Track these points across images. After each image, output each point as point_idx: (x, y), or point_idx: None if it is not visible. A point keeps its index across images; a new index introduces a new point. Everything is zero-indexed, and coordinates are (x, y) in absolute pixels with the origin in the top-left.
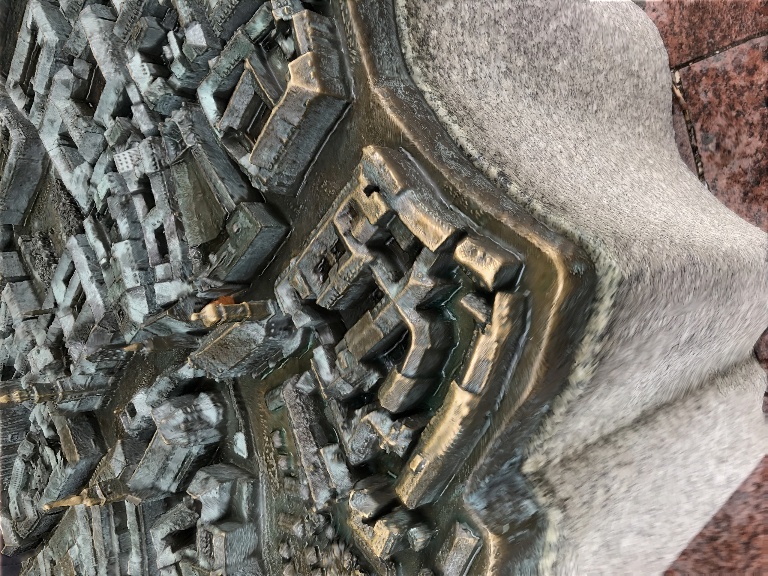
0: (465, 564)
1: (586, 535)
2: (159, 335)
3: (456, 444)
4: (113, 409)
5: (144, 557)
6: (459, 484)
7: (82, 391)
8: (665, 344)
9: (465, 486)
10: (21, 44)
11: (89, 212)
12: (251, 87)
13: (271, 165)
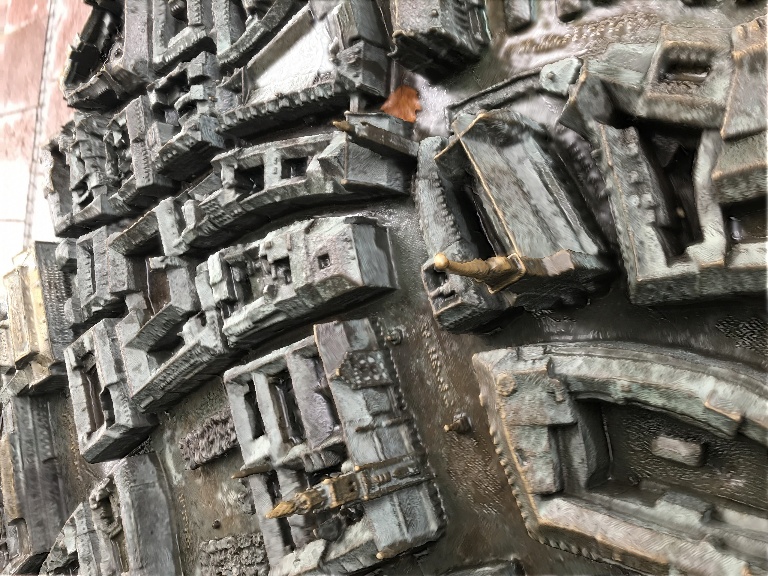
0: None
1: None
2: (371, 183)
3: None
4: (453, 492)
5: (710, 374)
6: None
7: (383, 463)
8: None
9: None
10: (75, 393)
11: (225, 347)
12: None
13: None
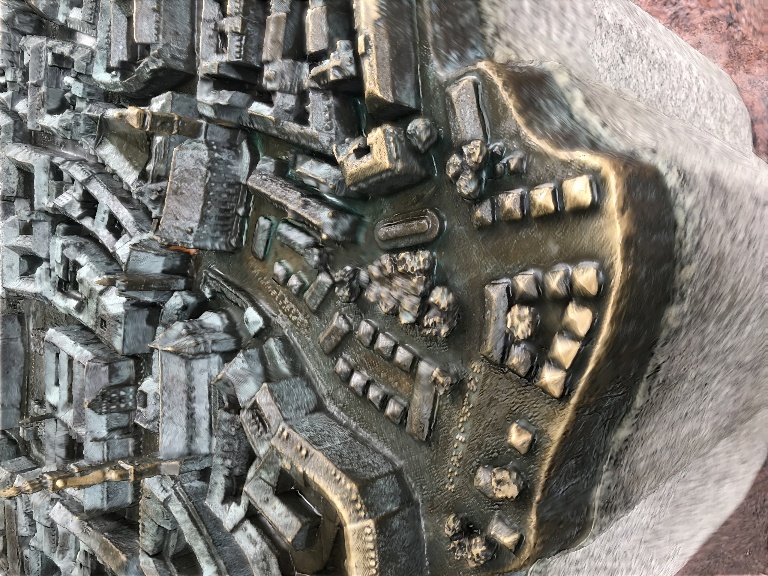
0: (477, 110)
1: (616, 107)
2: (139, 298)
3: (387, 6)
4: None
5: (218, 564)
6: (428, 69)
7: (101, 466)
8: (584, 2)
9: (433, 62)
10: None
11: None
12: (122, 16)
13: (156, 37)
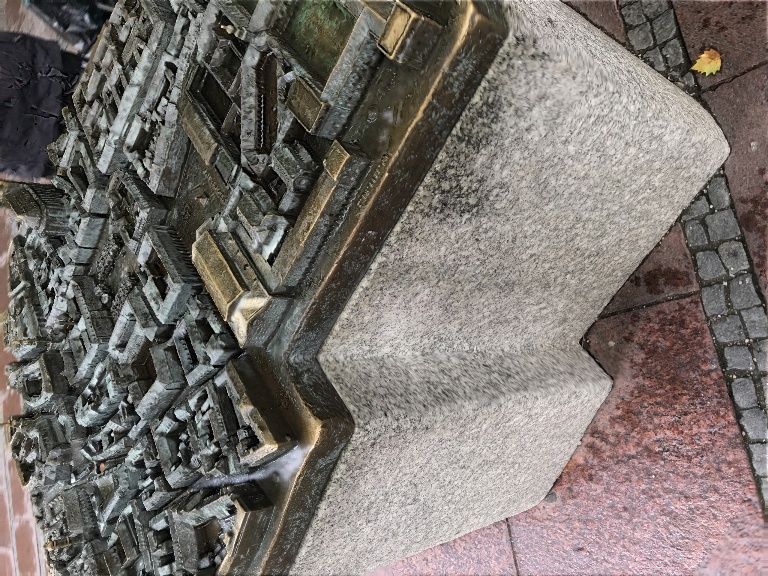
0: None
1: None
2: None
3: None
4: None
5: None
6: None
7: None
8: None
9: None
10: None
11: None
12: None
13: None
